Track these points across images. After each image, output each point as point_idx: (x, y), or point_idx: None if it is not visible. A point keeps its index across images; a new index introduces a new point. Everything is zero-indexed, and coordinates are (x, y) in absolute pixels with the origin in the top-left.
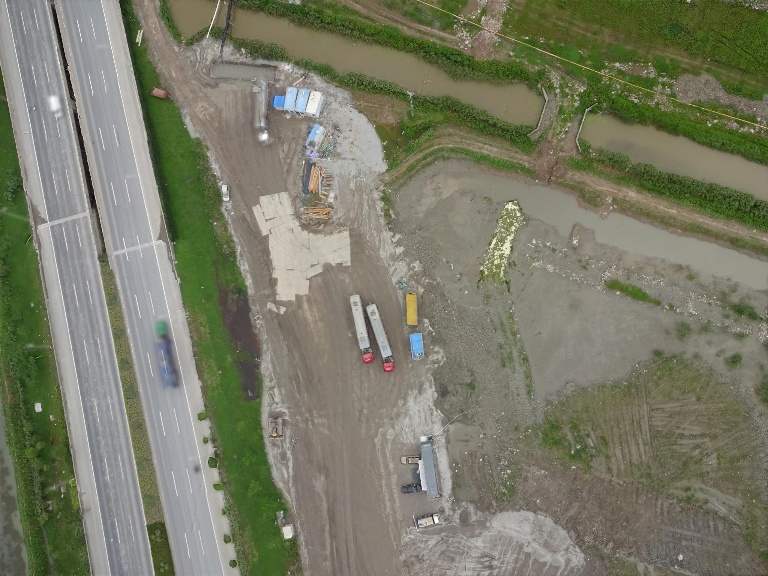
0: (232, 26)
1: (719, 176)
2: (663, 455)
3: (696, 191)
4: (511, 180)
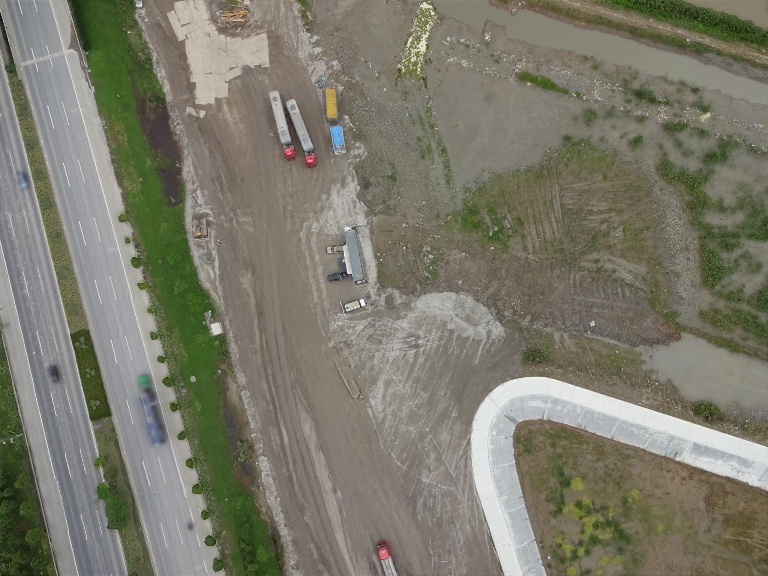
0: None
1: None
2: (574, 230)
3: None
4: None
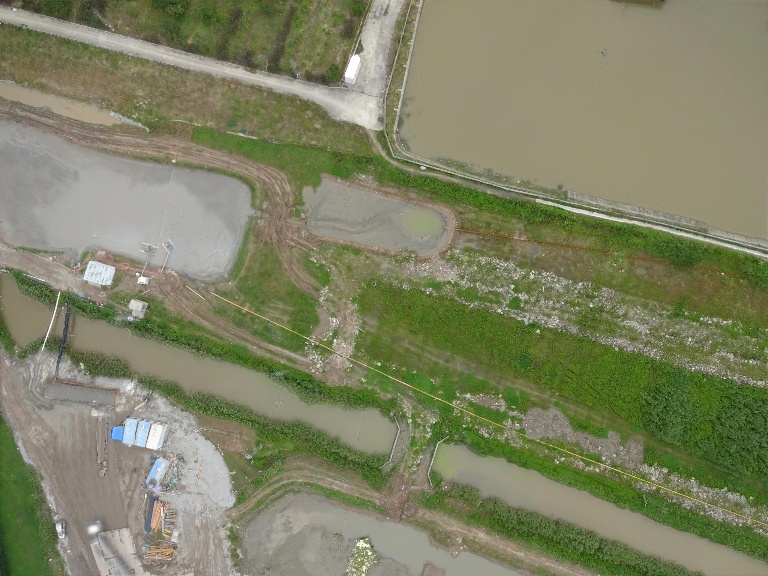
0: (70, 336)
1: (567, 512)
2: None
3: (543, 533)
4: (363, 515)
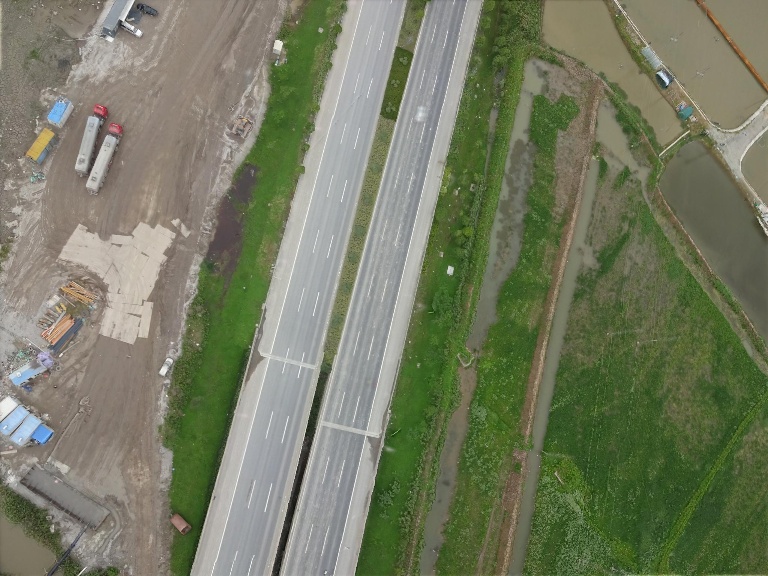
0: (48, 570)
1: None
2: None
3: None
4: None
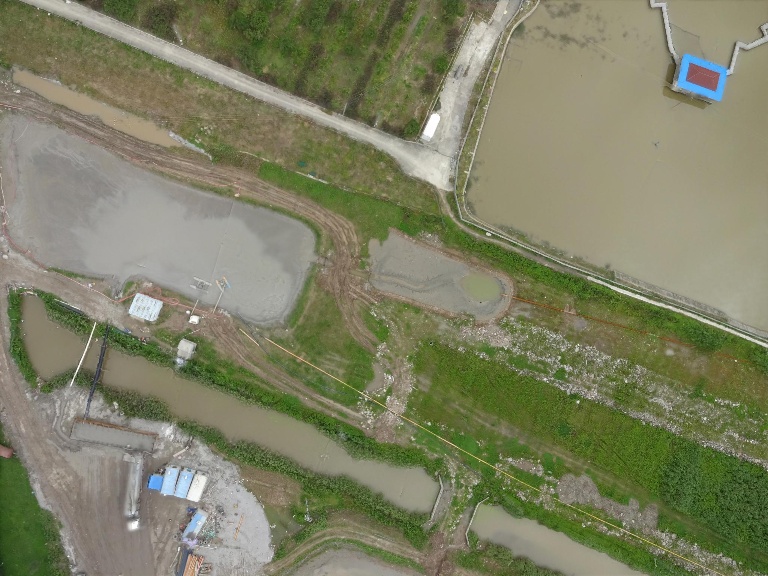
0: (104, 372)
1: (586, 572)
2: None
3: None
4: (400, 572)
